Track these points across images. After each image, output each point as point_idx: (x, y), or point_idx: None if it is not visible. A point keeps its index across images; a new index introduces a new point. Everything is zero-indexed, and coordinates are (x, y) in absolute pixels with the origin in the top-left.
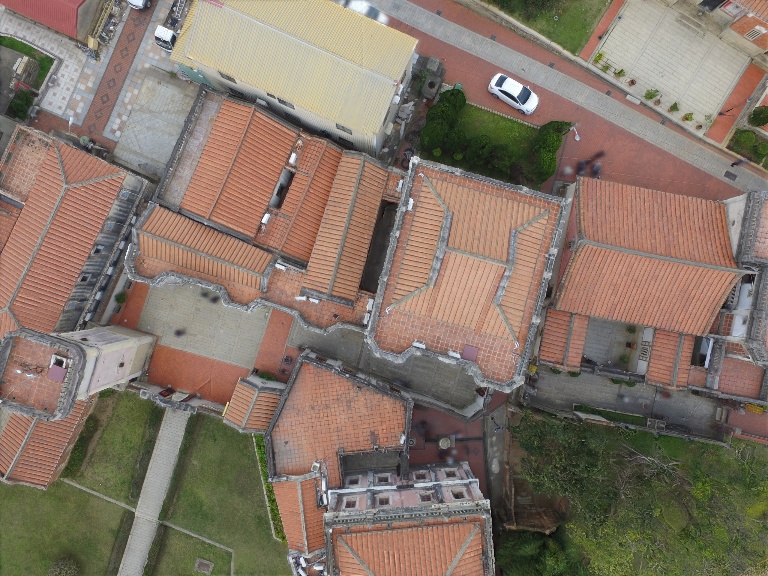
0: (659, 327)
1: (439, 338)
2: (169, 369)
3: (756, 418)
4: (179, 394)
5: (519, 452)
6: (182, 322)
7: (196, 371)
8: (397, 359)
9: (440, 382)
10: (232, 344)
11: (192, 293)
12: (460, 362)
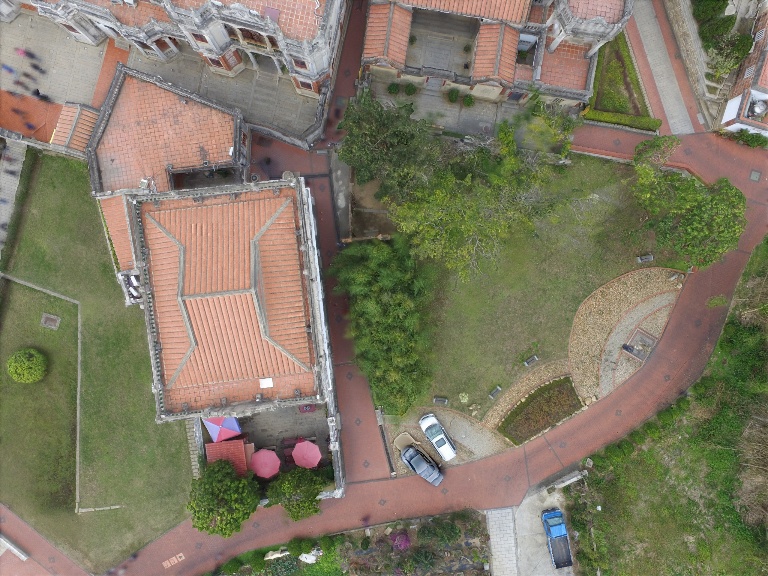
0: (478, 15)
1: (239, 1)
2: (1, 113)
3: (593, 134)
4: None
5: (365, 186)
6: (12, 63)
7: (30, 114)
8: (190, 13)
9: (281, 116)
10: (66, 85)
11: (21, 32)
12: None
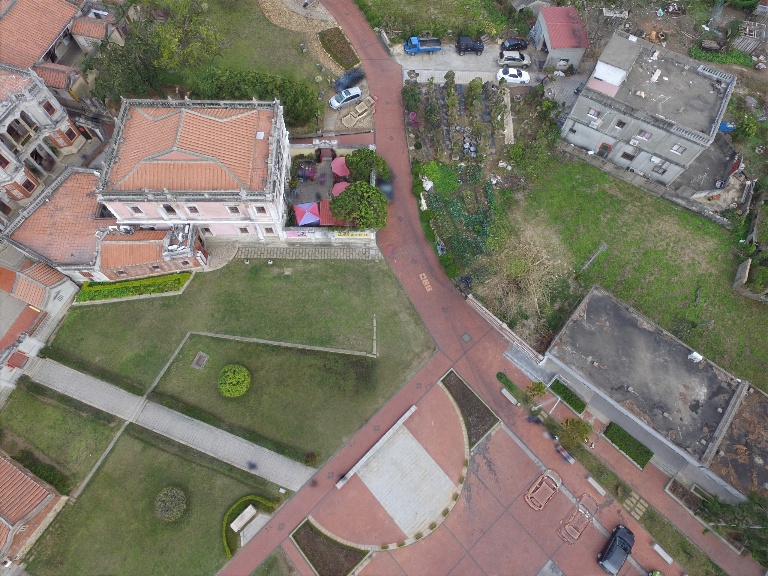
0: (63, 27)
1: None
2: None
3: None
4: (25, 366)
5: None
6: None
7: None
8: None
9: None
10: None
11: None
12: (1, 101)
